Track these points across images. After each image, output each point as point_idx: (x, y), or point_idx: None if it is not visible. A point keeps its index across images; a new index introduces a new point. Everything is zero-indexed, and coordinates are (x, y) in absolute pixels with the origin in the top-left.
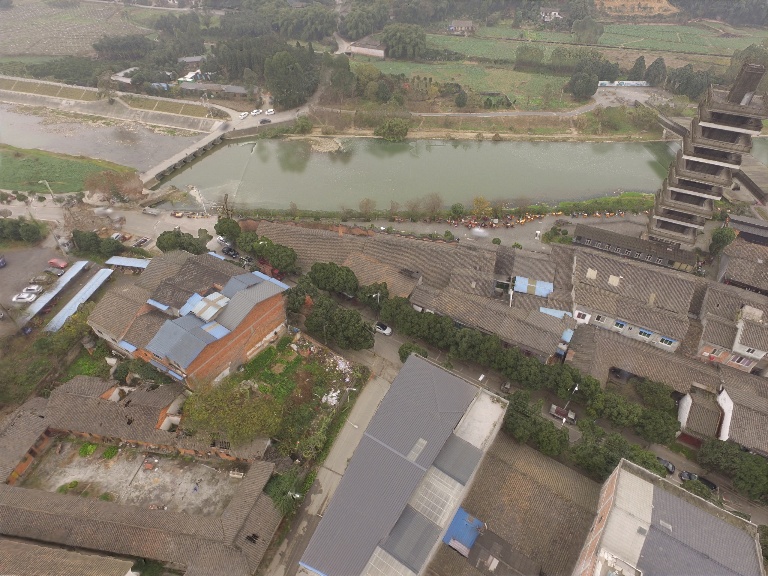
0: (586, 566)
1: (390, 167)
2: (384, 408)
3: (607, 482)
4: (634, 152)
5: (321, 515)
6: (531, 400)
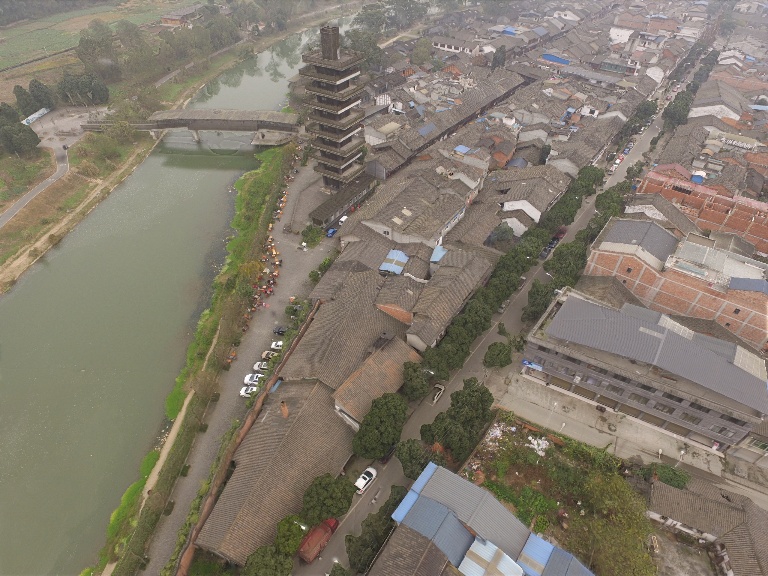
0: (661, 283)
1: (40, 368)
2: (621, 351)
3: (591, 267)
4: (168, 161)
5: (659, 455)
6: (508, 298)
